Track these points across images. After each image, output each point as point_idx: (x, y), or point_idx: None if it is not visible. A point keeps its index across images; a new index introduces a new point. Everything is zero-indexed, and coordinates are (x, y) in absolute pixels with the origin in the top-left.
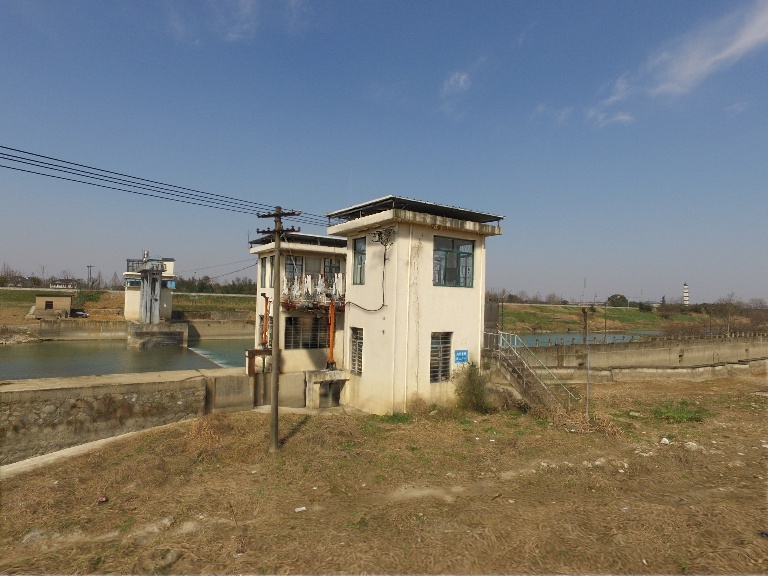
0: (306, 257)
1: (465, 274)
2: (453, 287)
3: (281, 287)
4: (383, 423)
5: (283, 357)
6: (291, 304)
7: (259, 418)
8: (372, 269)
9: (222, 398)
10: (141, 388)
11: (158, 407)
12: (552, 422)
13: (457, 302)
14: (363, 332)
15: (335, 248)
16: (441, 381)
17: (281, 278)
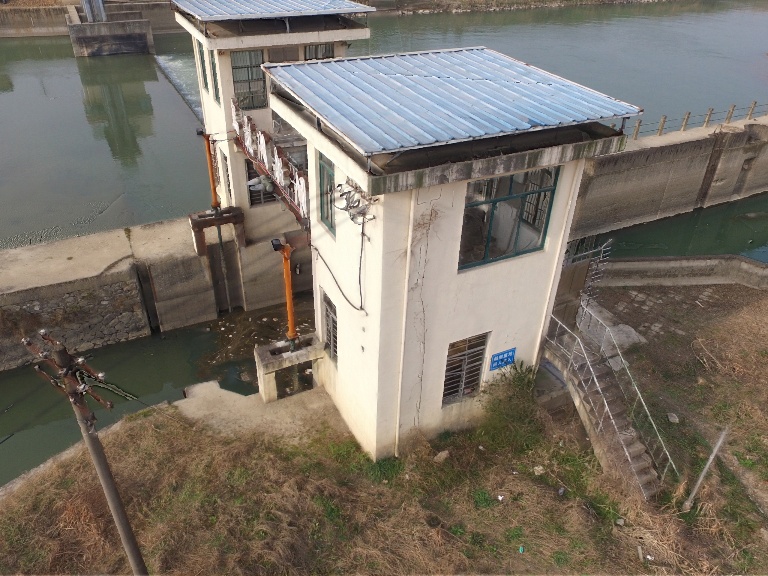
0: (269, 49)
1: (537, 202)
2: (501, 263)
3: (230, 111)
4: (359, 478)
5: (250, 218)
6: (246, 154)
7: (179, 450)
8: (345, 229)
9: (165, 288)
10: (42, 293)
11: (75, 312)
12: (623, 519)
13: (506, 285)
14: (337, 315)
15: (320, 33)
16: (462, 398)
17: (228, 95)
